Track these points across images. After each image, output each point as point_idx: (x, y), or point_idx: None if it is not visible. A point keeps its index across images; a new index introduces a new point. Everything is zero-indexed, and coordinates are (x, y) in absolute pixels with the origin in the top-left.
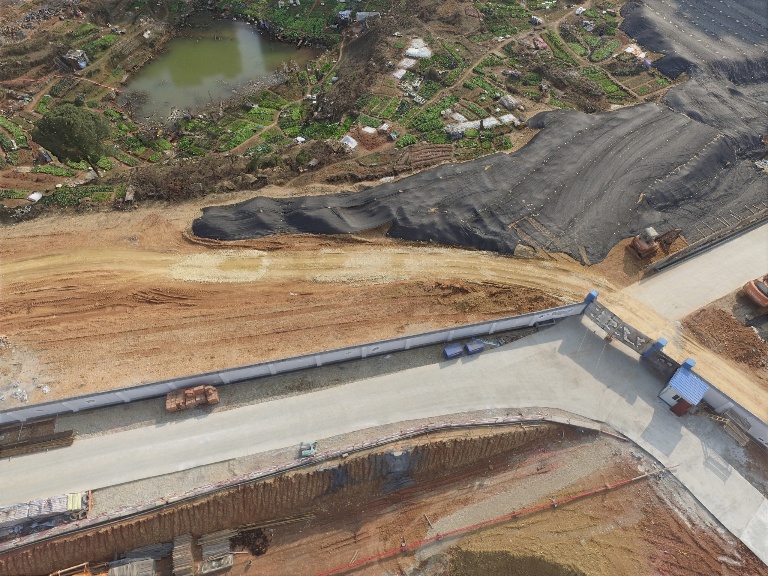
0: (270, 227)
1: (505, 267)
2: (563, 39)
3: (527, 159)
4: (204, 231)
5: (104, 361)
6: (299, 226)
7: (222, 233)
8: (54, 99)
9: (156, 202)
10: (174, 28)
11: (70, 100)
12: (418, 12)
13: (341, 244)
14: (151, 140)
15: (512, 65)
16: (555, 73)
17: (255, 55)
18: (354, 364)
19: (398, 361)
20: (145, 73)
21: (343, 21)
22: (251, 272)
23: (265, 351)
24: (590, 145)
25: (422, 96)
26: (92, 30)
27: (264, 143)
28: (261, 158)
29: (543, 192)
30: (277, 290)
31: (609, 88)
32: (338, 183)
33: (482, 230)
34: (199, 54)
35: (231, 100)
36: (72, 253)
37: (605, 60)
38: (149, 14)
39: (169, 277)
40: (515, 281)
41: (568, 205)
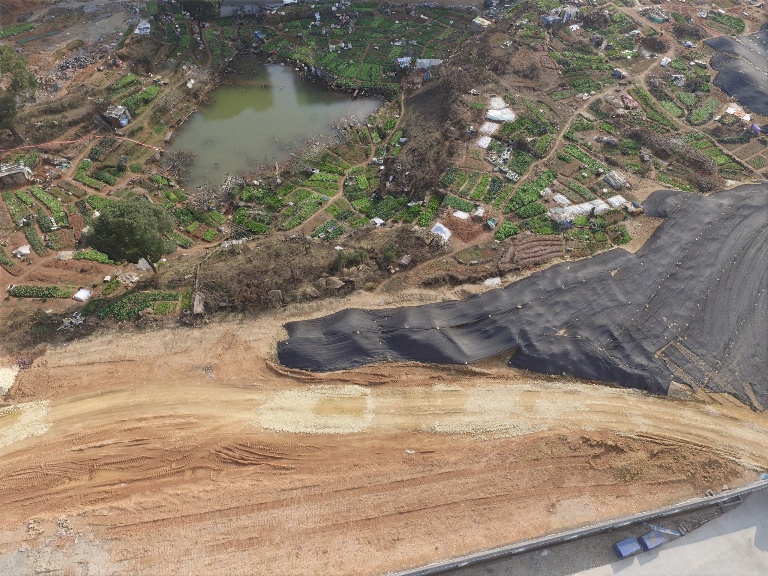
0: (369, 353)
1: (659, 412)
2: (654, 96)
3: (657, 261)
4: (292, 360)
5: (191, 558)
6: (403, 351)
7: (314, 362)
8: (94, 163)
9: (229, 315)
10: (218, 75)
11: (111, 164)
12: (490, 63)
13: (456, 377)
14: (203, 212)
15: (609, 132)
16: (658, 142)
17: (308, 107)
18: (504, 564)
19: (559, 560)
20: (190, 128)
21: (402, 68)
22: (355, 419)
23: (389, 542)
24: (725, 241)
25: (514, 170)
26: (133, 81)
27: (334, 221)
28: (345, 255)
29: (685, 306)
30: (389, 445)
31: (719, 159)
32: (436, 287)
33: (624, 361)
34: (247, 105)
35: (290, 165)
36: (137, 389)
37: (707, 123)
38: (192, 60)
39: (257, 426)
40: (676, 433)
41: (717, 324)
